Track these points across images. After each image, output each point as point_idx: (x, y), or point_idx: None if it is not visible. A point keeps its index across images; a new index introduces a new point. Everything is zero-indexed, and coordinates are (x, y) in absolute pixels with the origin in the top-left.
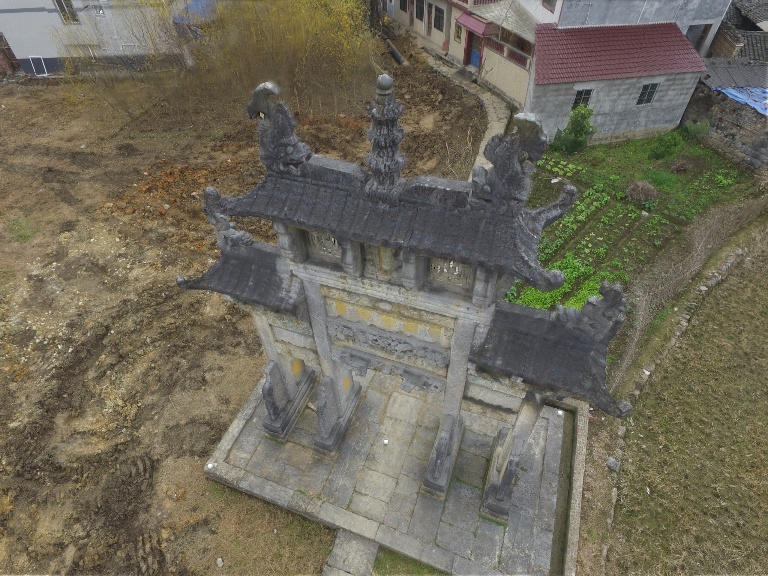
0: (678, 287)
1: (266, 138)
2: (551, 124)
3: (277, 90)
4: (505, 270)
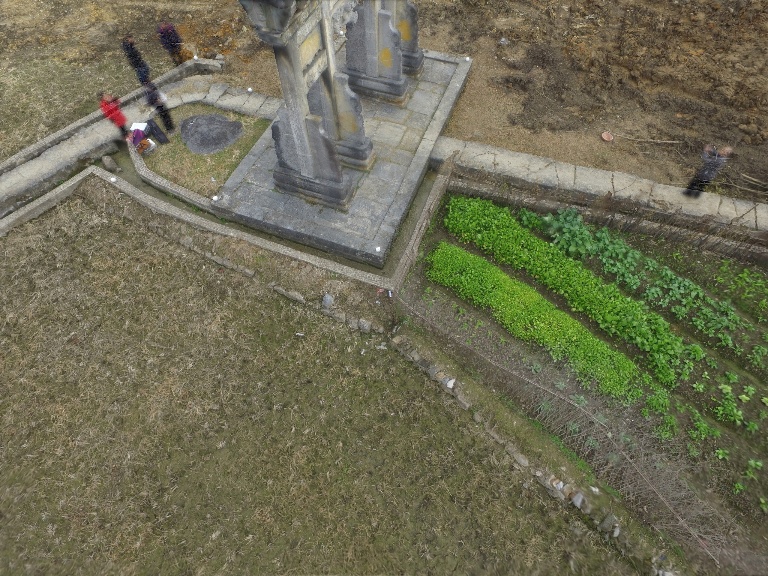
0: (653, 512)
1: None
2: None
3: None
4: None
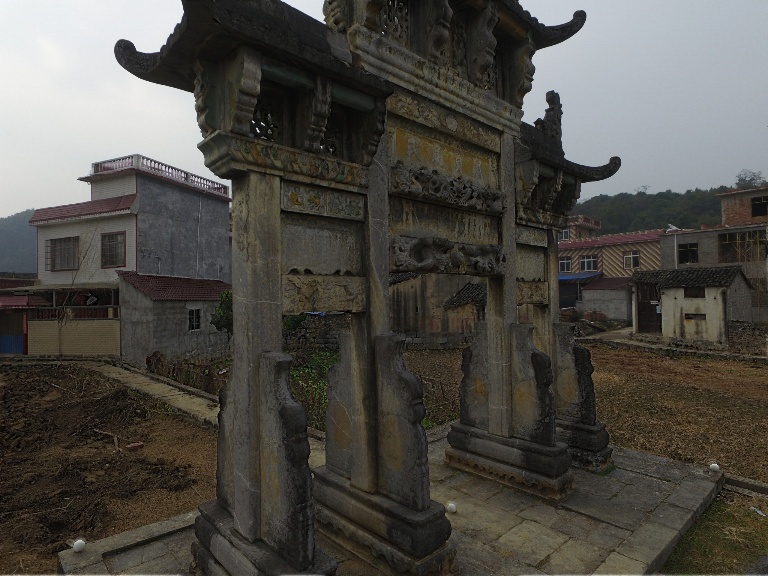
0: None
1: None
2: (175, 344)
3: None
4: (546, 30)
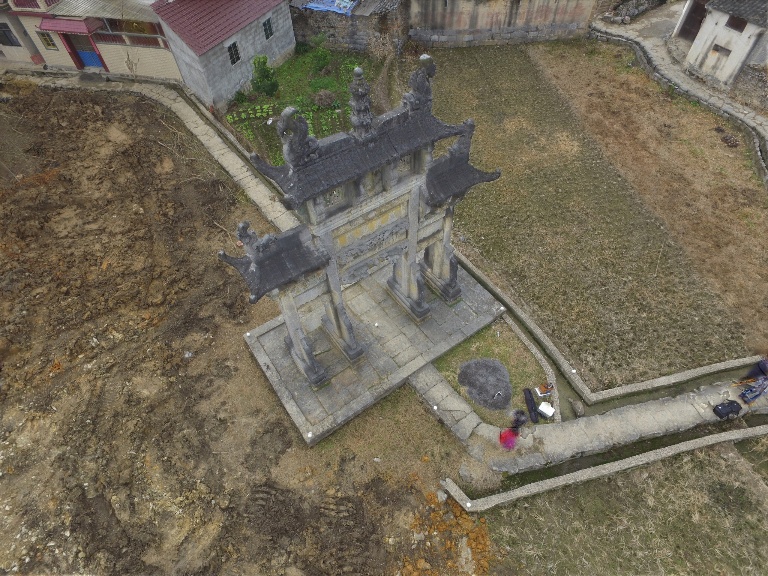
0: None
1: (295, 145)
2: (225, 83)
3: None
4: None
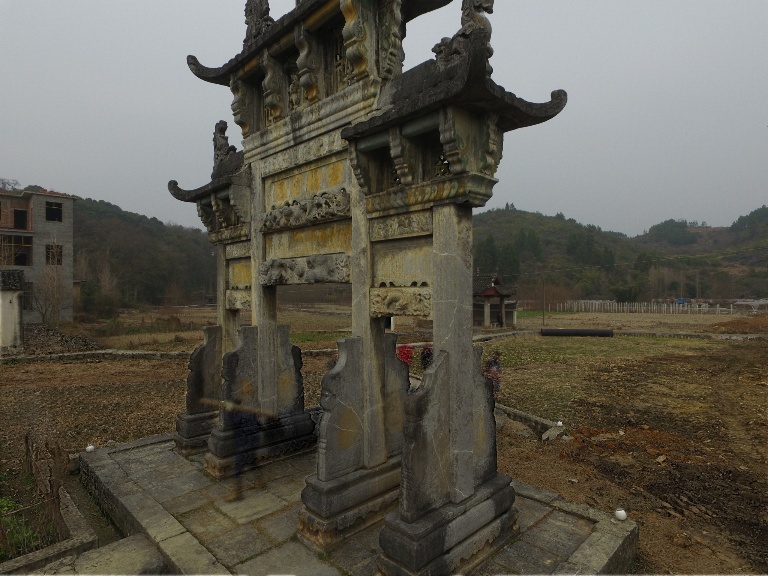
0: None
1: None
2: None
3: None
4: None
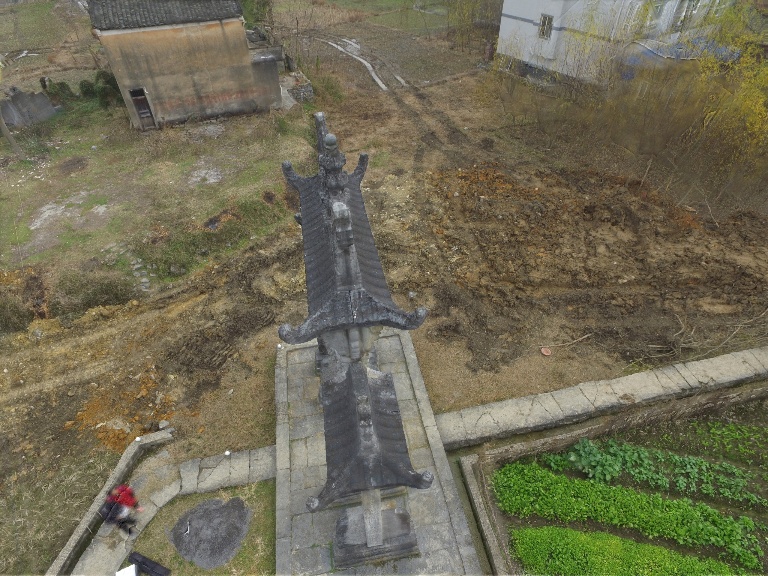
0: None
1: None
2: None
3: (323, 119)
4: None
